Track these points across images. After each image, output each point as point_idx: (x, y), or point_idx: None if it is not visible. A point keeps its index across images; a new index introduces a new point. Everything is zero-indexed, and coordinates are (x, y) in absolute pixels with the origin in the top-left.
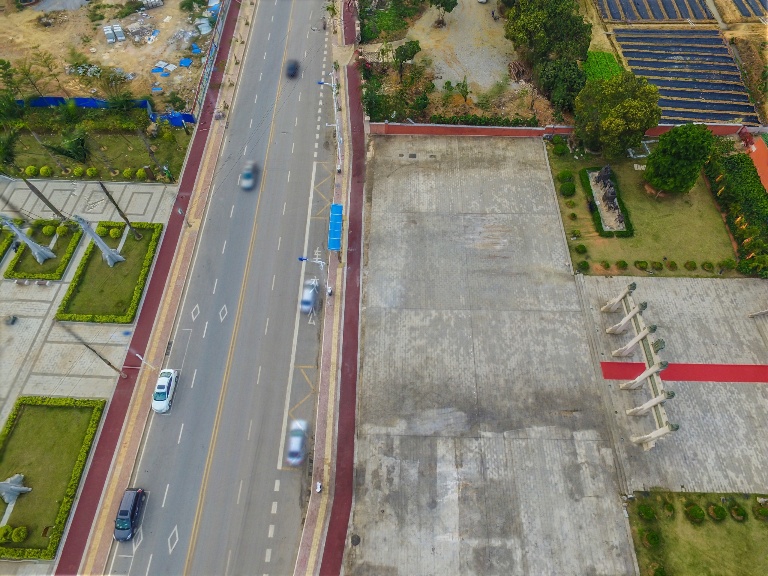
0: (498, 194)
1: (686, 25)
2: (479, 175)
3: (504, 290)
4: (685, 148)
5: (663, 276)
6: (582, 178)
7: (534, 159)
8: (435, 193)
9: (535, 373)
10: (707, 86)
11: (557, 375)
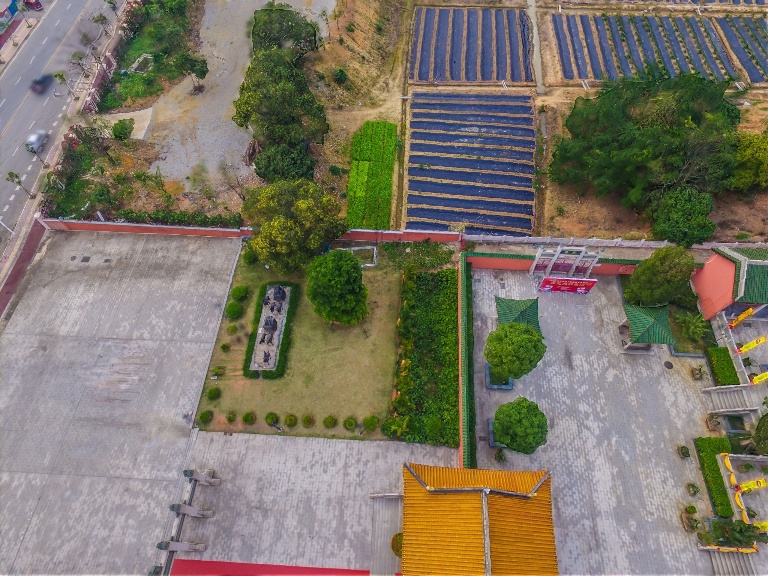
0: (157, 313)
1: (498, 88)
2: (148, 287)
3: (102, 447)
4: (317, 284)
5: (293, 435)
6: (258, 296)
7: (220, 267)
8: (87, 310)
9: (82, 569)
10: (491, 165)
11: (106, 574)
